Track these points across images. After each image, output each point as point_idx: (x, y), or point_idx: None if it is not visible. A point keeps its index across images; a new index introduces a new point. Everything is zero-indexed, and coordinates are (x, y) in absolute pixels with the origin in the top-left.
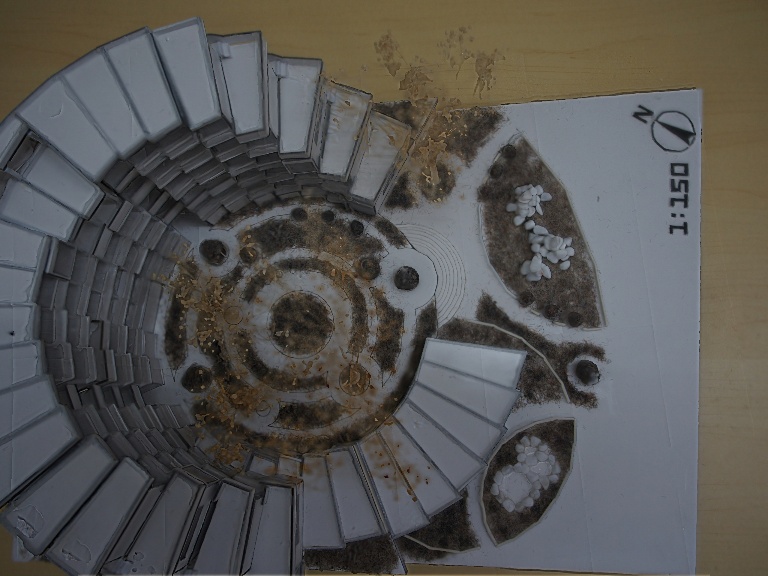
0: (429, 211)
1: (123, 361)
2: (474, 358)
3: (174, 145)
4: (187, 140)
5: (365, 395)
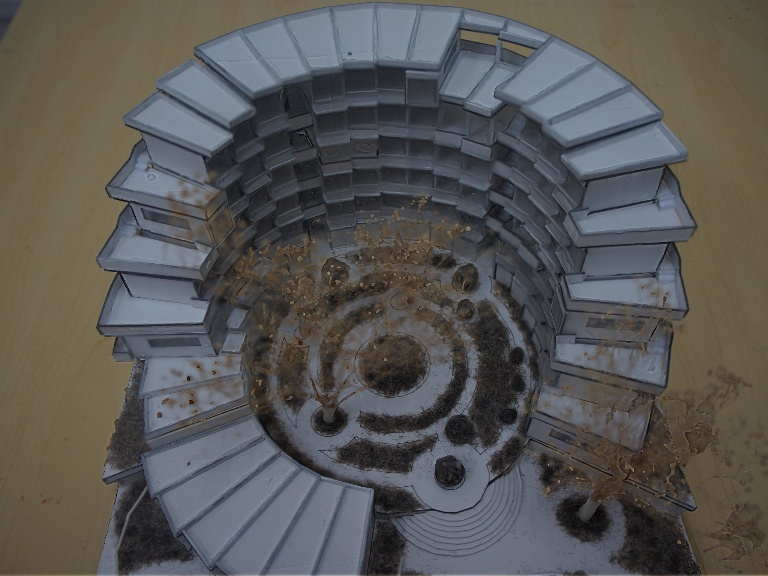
0: (543, 508)
1: (345, 189)
2: (347, 550)
3: (547, 159)
4: (555, 169)
5: (311, 432)
